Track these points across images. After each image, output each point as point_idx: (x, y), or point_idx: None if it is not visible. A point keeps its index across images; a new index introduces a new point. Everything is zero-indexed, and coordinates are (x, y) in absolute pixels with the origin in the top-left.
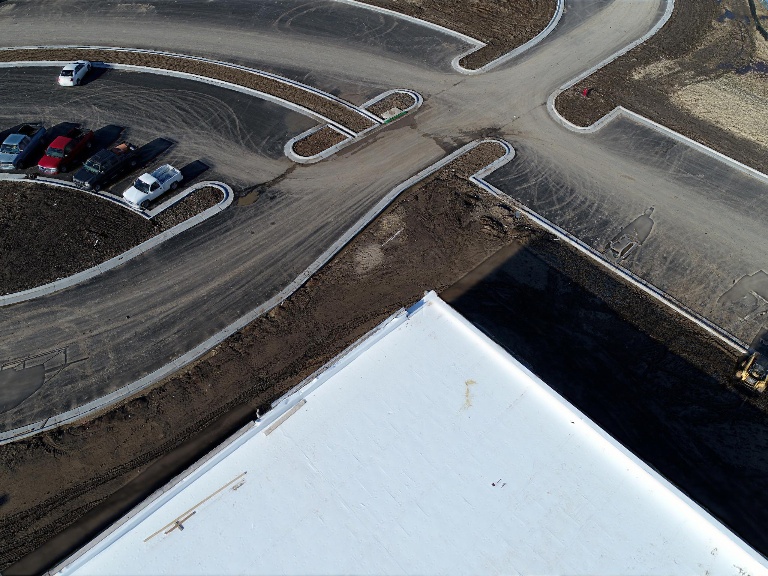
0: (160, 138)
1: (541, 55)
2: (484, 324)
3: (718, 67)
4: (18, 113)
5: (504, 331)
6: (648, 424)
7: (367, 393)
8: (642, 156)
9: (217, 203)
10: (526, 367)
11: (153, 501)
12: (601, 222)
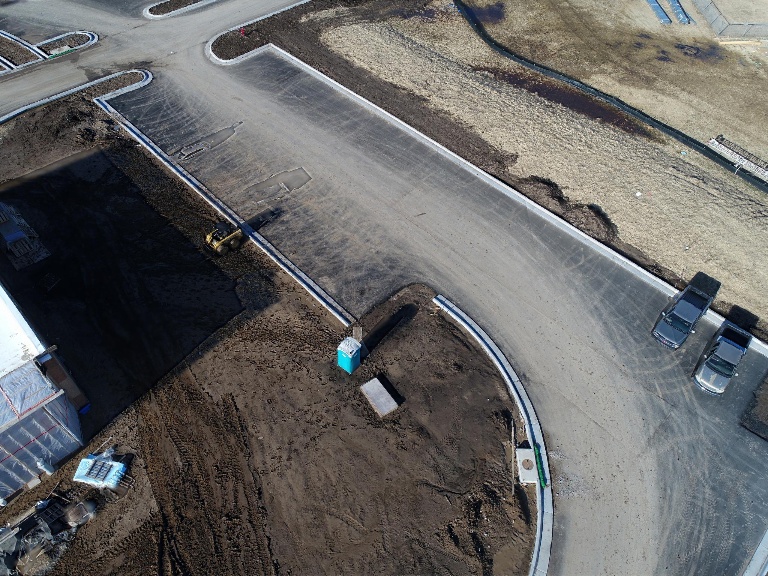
0: None
1: (231, 3)
2: (20, 206)
3: (389, 13)
4: None
5: (34, 211)
6: (108, 275)
7: None
8: (263, 82)
9: None
10: None
11: None
12: (187, 133)
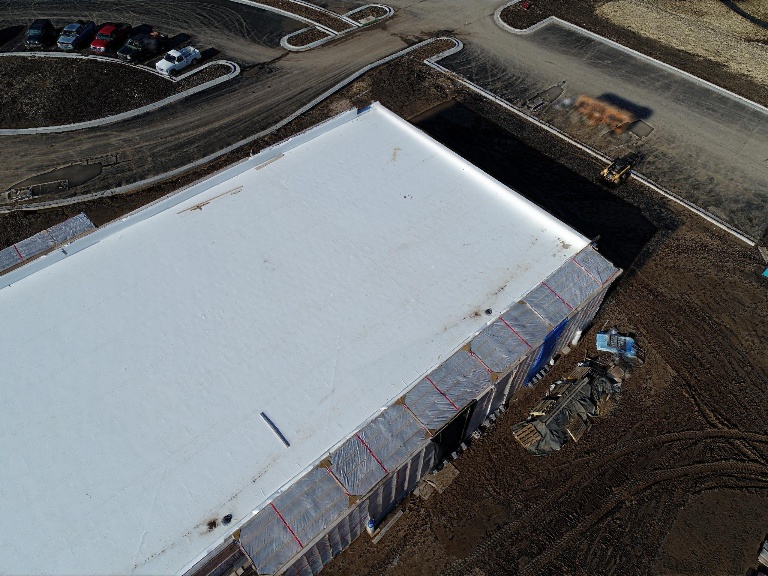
0: (183, 33)
1: None
2: None
3: None
4: (72, 16)
5: None
6: None
7: (326, 152)
8: (564, 49)
9: (227, 74)
10: (436, 140)
11: (183, 190)
12: (522, 89)
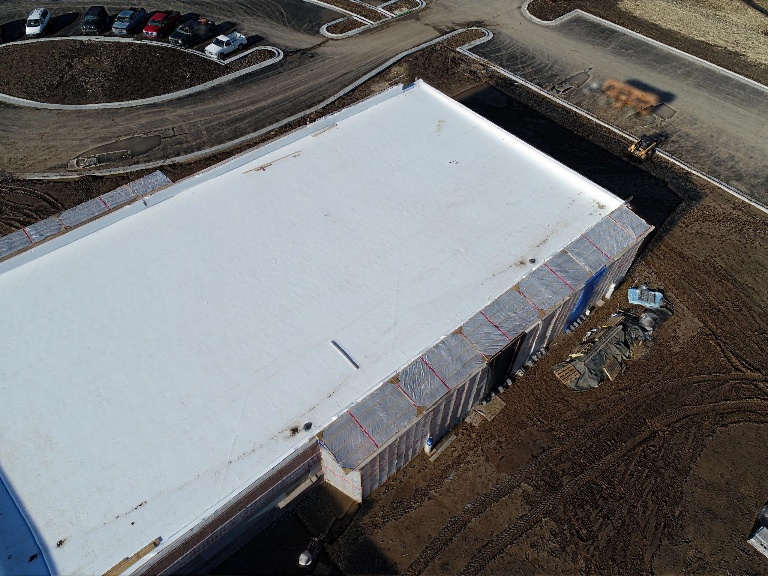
0: (228, 21)
1: None
2: None
3: None
4: (122, 4)
5: None
6: None
7: (375, 123)
8: (589, 39)
9: (272, 58)
10: (477, 113)
11: (248, 152)
12: (551, 75)
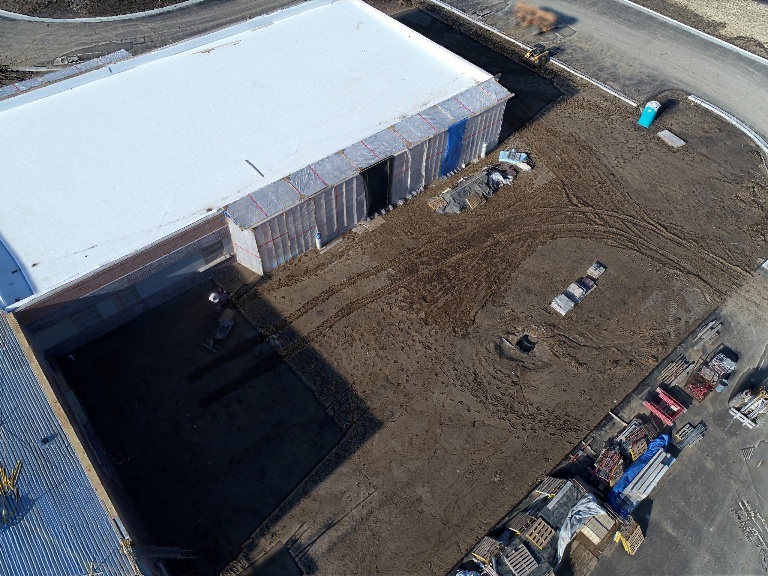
0: None
1: None
2: None
3: None
4: None
5: None
6: None
7: (305, 23)
8: None
9: None
10: (391, 17)
11: (196, 38)
12: (475, 3)
